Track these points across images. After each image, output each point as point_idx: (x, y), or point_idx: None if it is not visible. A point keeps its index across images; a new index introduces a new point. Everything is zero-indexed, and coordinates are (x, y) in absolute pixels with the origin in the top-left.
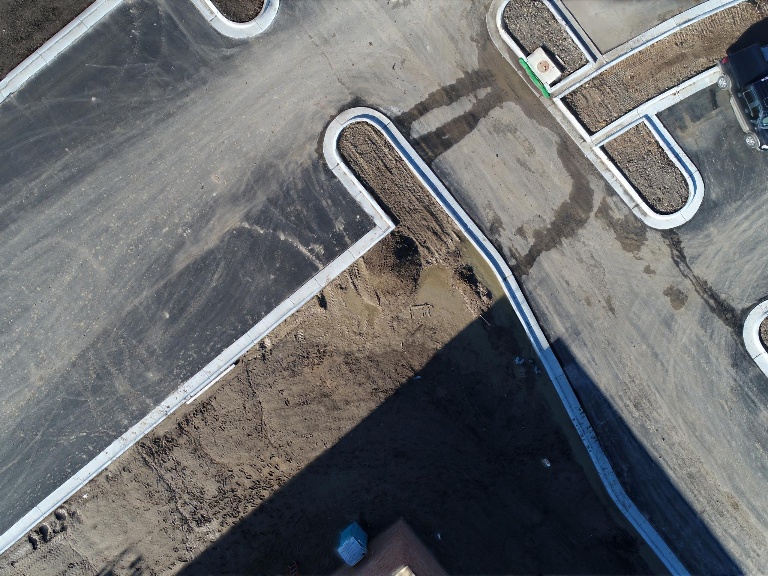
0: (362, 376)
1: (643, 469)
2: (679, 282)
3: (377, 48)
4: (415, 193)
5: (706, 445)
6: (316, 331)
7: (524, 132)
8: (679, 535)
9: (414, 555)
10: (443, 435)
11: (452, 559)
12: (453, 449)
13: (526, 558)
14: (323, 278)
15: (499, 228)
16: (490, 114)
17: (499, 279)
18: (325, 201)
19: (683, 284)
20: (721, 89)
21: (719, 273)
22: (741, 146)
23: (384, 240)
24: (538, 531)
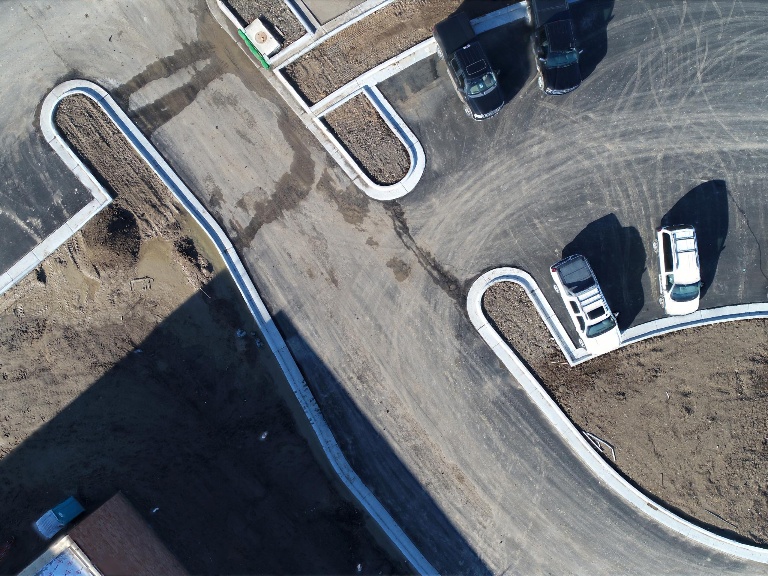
0: (81, 350)
1: (367, 441)
2: (402, 253)
3: (93, 20)
4: (133, 166)
5: (431, 417)
6: (35, 305)
7: (244, 104)
8: (405, 507)
9: (104, 526)
10: (163, 409)
11: (173, 533)
12: (173, 422)
13: (249, 531)
14: (41, 252)
15: (219, 200)
16: (209, 86)
17: (218, 251)
18: (43, 174)
19: (406, 255)
20: (441, 59)
21: (442, 244)
22: (462, 116)
23: (102, 213)
24: (260, 504)
